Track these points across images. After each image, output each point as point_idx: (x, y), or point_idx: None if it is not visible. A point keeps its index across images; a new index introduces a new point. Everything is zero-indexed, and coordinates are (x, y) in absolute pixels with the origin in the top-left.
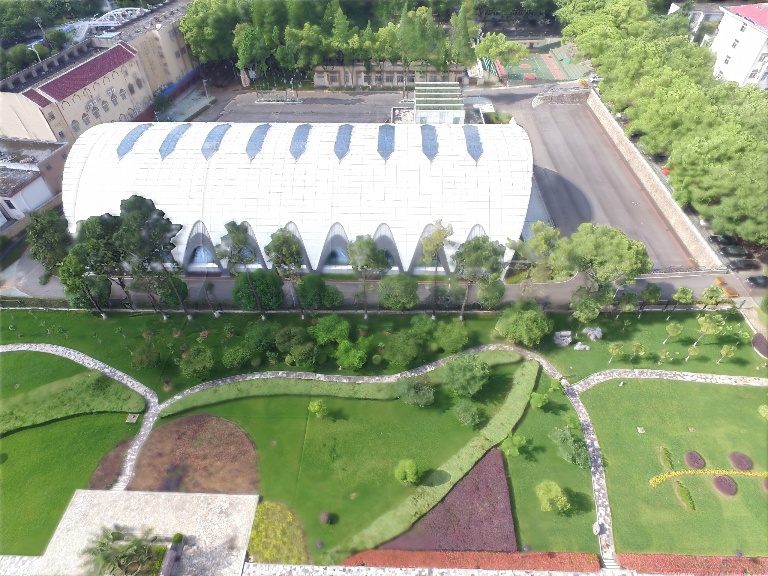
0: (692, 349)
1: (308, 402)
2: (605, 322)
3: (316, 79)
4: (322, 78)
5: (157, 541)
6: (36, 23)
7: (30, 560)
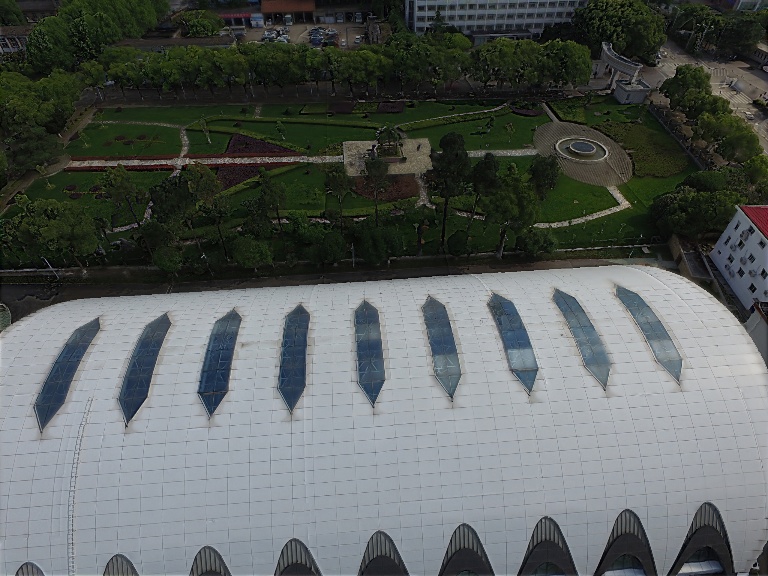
0: None
1: None
2: None
3: None
4: None
5: None
6: None
7: None
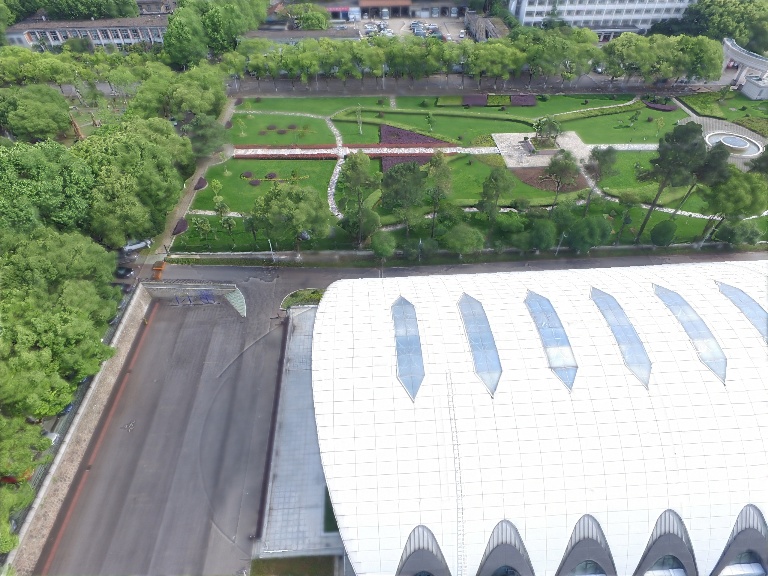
0: None
1: None
2: (288, 245)
3: None
4: None
5: None
6: None
7: None
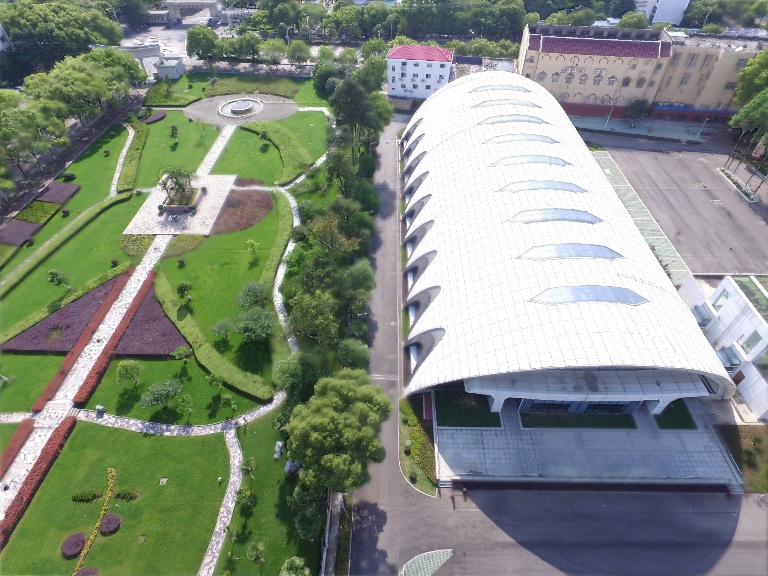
0: (224, 571)
1: (268, 249)
2: None
3: None
4: None
5: (194, 201)
6: (725, 16)
7: (207, 172)
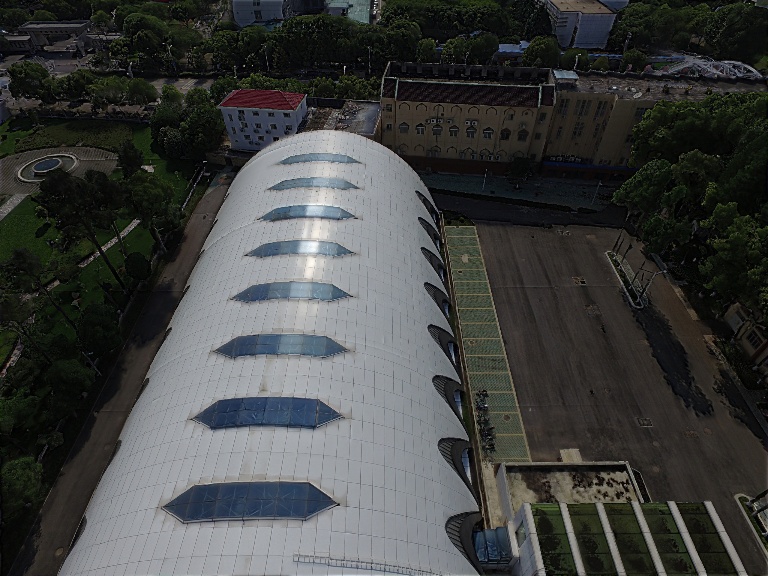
0: None
1: None
2: None
3: (733, 311)
4: (742, 320)
5: None
6: (652, 39)
7: None
